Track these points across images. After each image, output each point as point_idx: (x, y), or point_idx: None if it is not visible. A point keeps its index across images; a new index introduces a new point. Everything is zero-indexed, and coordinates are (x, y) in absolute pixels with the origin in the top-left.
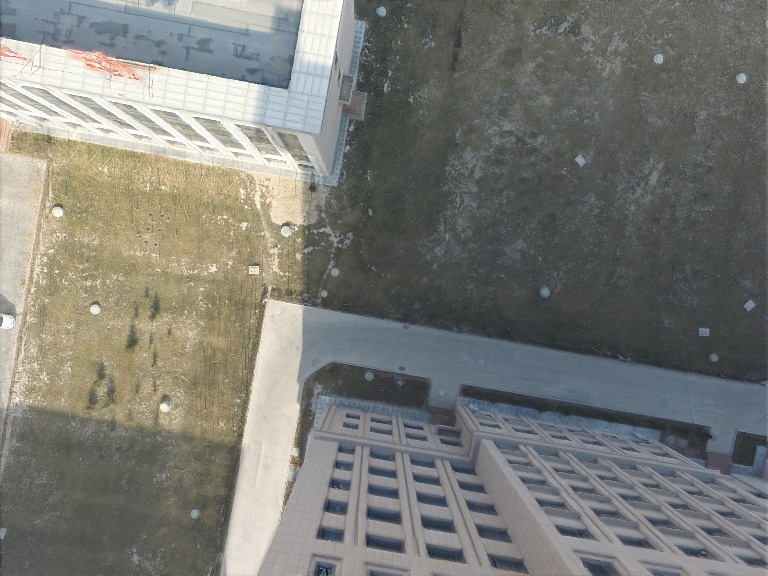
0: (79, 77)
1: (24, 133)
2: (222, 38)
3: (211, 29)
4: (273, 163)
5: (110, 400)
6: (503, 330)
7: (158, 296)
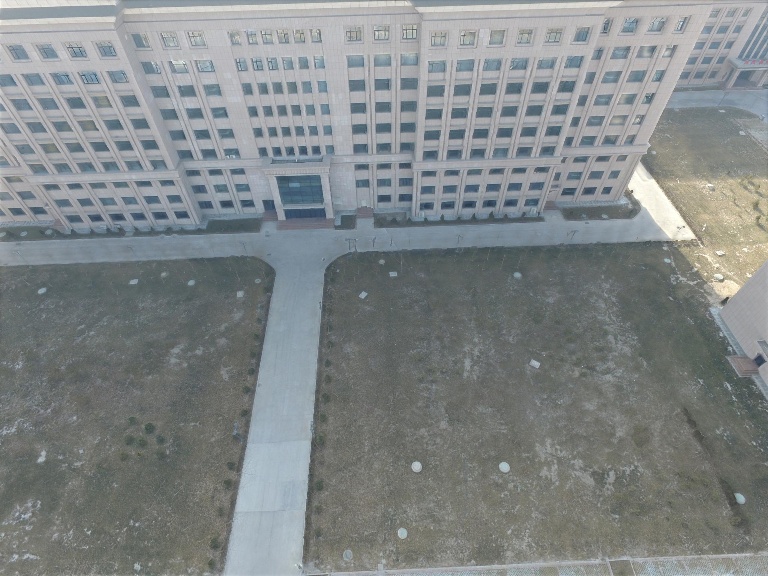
0: None
1: None
2: None
3: None
4: None
5: (742, 184)
6: (535, 251)
7: (765, 231)
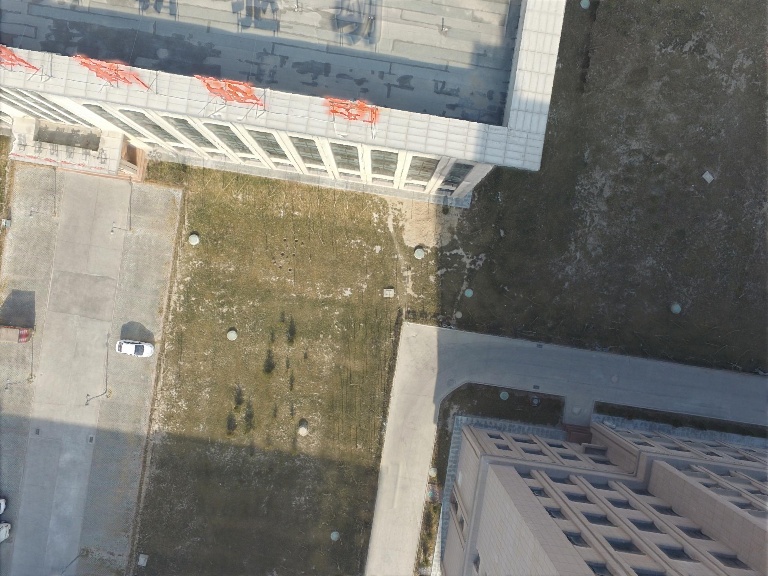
0: (303, 120)
1: (159, 162)
2: (423, 75)
3: (412, 66)
4: (408, 187)
5: (248, 425)
6: (635, 347)
7: (293, 321)
